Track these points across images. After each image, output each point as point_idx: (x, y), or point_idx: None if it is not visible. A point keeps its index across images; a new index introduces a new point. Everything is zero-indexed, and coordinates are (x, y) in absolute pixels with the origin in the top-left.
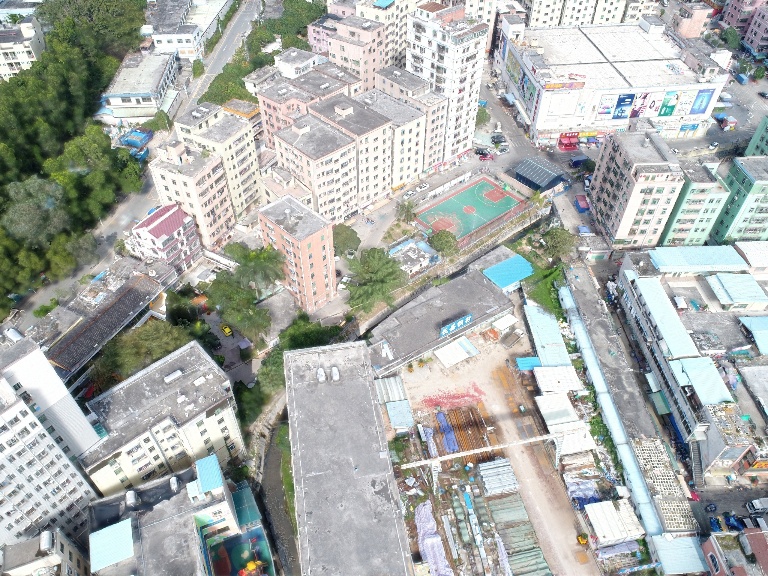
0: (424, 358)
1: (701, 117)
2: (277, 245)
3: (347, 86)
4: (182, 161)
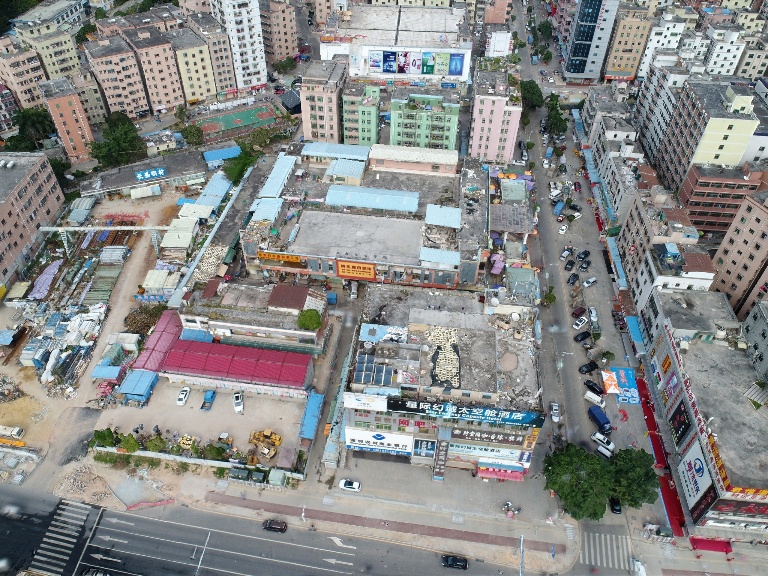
0: (124, 194)
1: (460, 78)
2: None
3: (163, 22)
4: (9, 52)
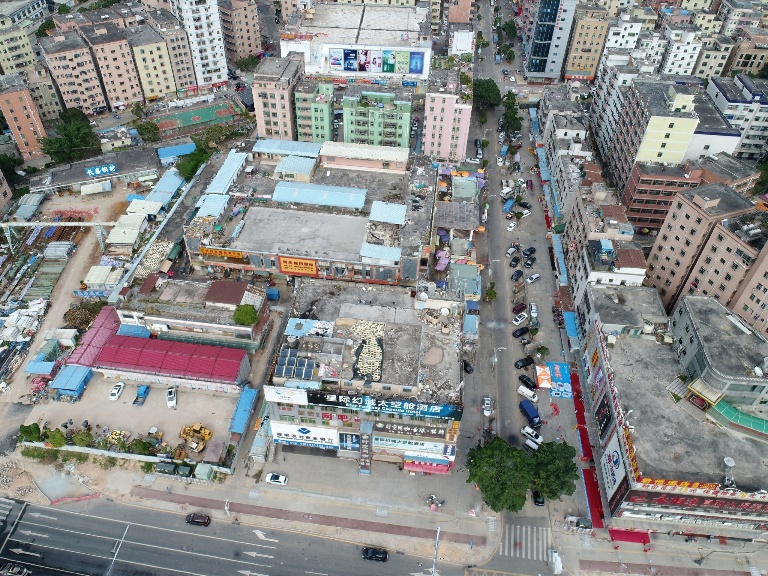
0: (75, 190)
1: (421, 77)
2: None
3: (122, 19)
4: None
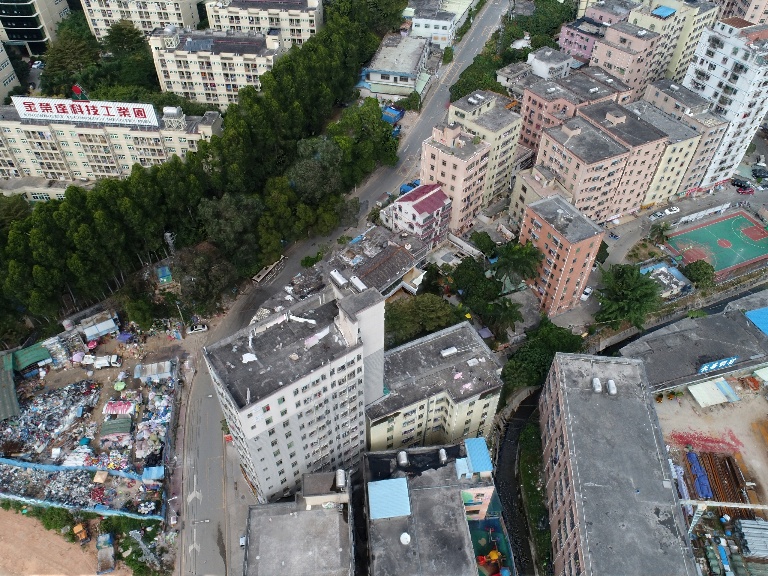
0: (675, 391)
1: None
2: (538, 243)
3: (617, 93)
4: (454, 144)
